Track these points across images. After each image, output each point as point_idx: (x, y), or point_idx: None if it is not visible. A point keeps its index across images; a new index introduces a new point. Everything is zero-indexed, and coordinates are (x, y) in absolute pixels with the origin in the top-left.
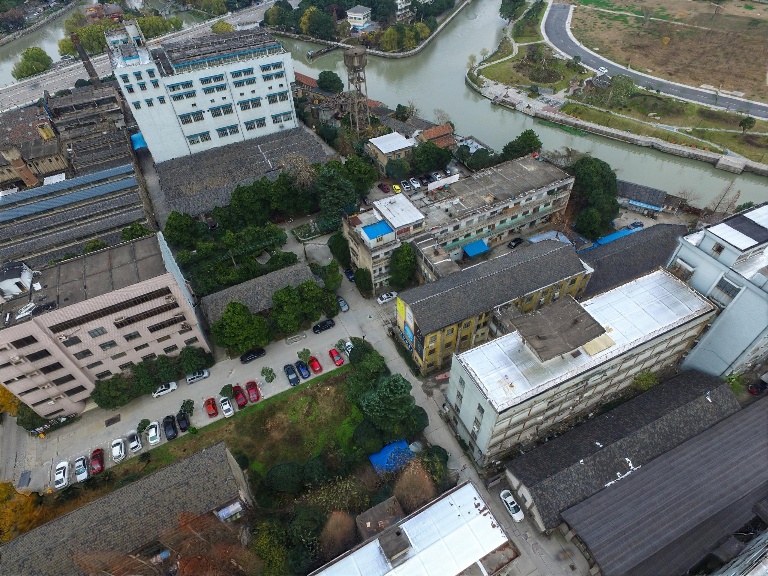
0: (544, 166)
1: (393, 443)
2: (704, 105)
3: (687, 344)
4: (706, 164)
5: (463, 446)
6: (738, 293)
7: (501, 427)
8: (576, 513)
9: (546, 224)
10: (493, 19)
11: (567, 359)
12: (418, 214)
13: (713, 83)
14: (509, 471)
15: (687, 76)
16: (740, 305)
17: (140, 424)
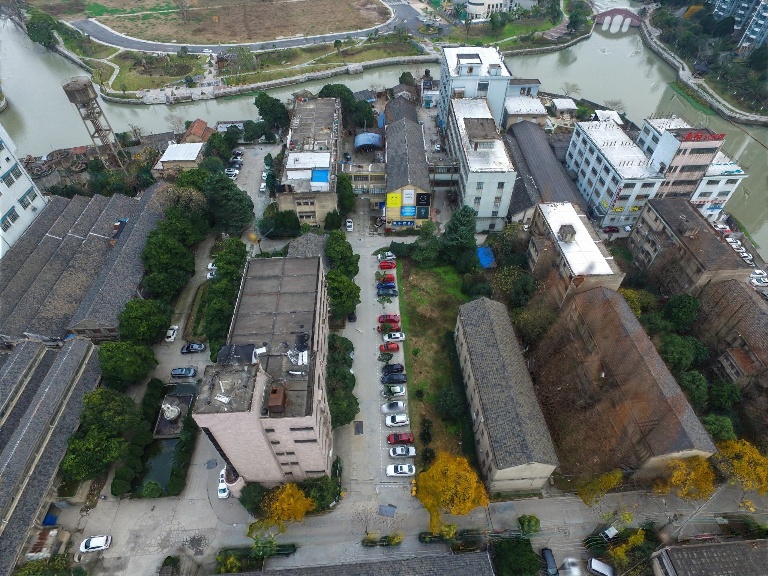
0: (315, 102)
1: None
2: (297, 47)
3: None
4: (343, 75)
5: (487, 233)
6: (489, 85)
7: None
8: (548, 200)
9: (341, 140)
10: (24, 53)
11: None
12: (323, 154)
13: (279, 35)
14: (516, 215)
15: (260, 36)
16: (491, 91)
17: (385, 393)
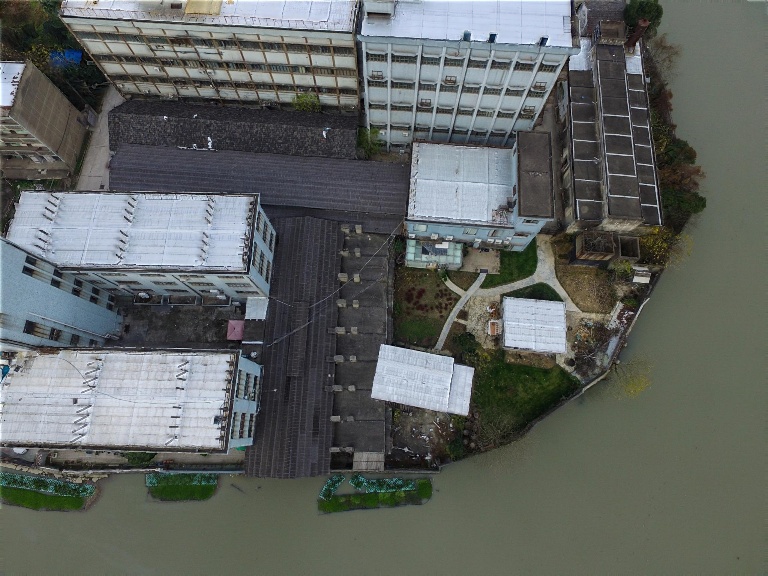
0: None
1: (70, 49)
2: None
3: (357, 83)
4: None
5: None
6: None
7: (103, 50)
8: (131, 147)
9: None
10: None
11: (163, 6)
12: None
13: None
14: None
15: None
16: None
17: None
